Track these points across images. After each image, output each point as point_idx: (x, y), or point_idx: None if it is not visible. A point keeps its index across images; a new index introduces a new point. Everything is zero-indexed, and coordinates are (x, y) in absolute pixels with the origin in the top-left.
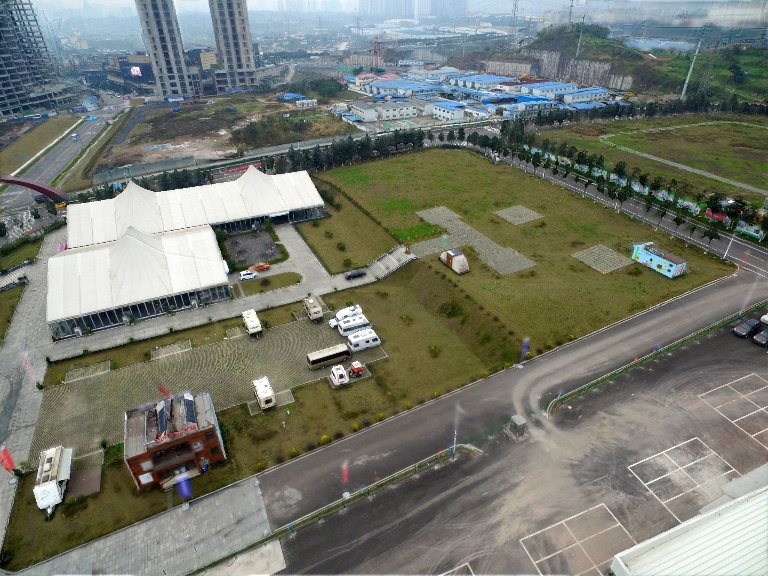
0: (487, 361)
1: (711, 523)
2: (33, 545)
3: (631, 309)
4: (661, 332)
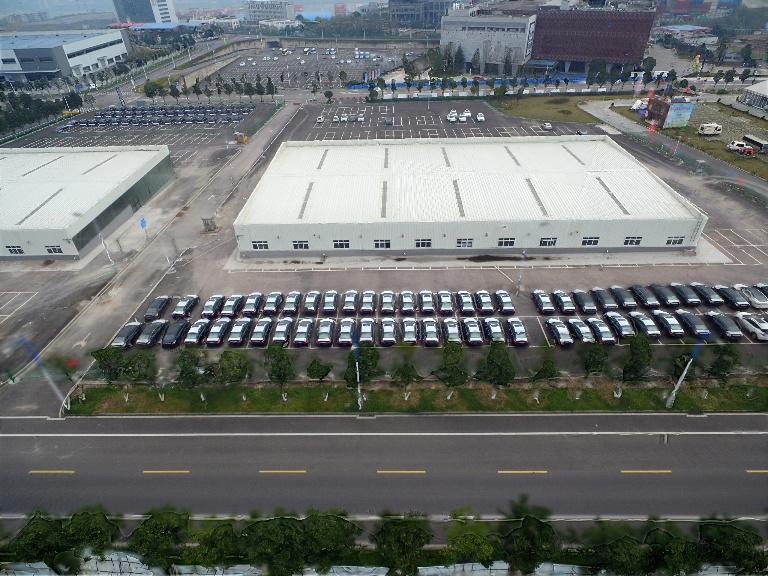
0: None
1: (624, 155)
2: None
3: None
4: None
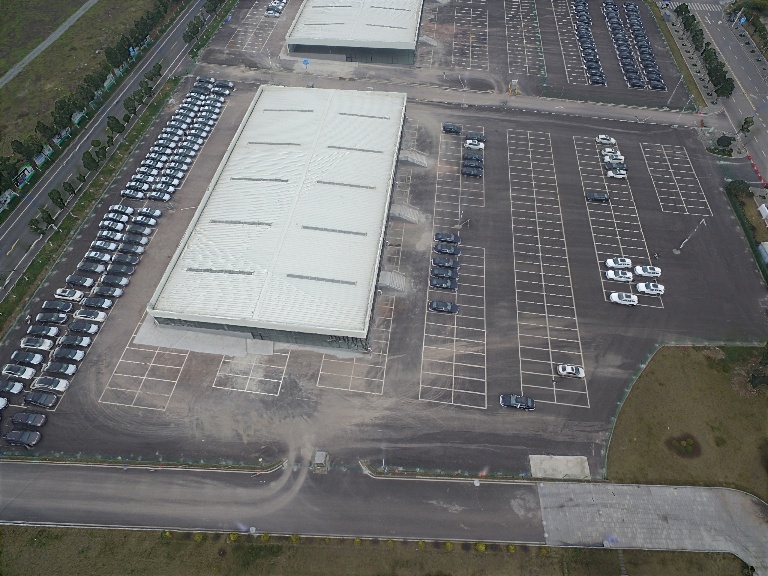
0: (264, 575)
1: None
2: (730, 575)
3: (56, 538)
4: (86, 486)
